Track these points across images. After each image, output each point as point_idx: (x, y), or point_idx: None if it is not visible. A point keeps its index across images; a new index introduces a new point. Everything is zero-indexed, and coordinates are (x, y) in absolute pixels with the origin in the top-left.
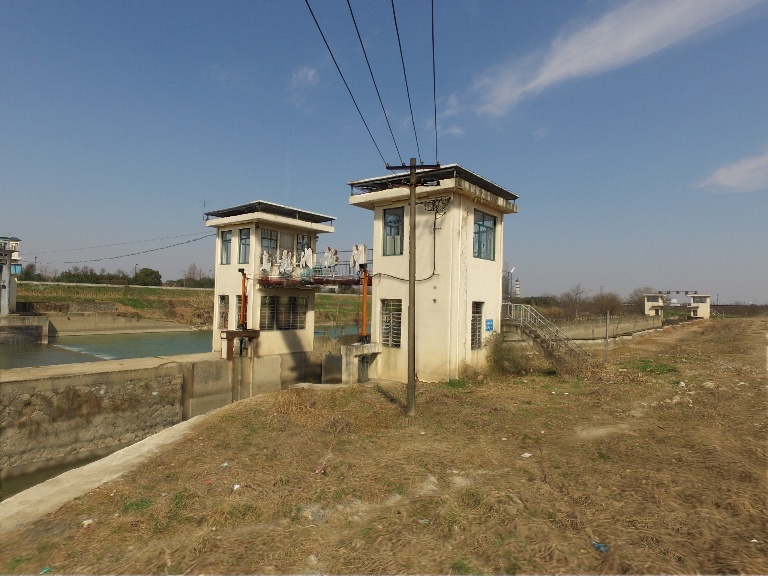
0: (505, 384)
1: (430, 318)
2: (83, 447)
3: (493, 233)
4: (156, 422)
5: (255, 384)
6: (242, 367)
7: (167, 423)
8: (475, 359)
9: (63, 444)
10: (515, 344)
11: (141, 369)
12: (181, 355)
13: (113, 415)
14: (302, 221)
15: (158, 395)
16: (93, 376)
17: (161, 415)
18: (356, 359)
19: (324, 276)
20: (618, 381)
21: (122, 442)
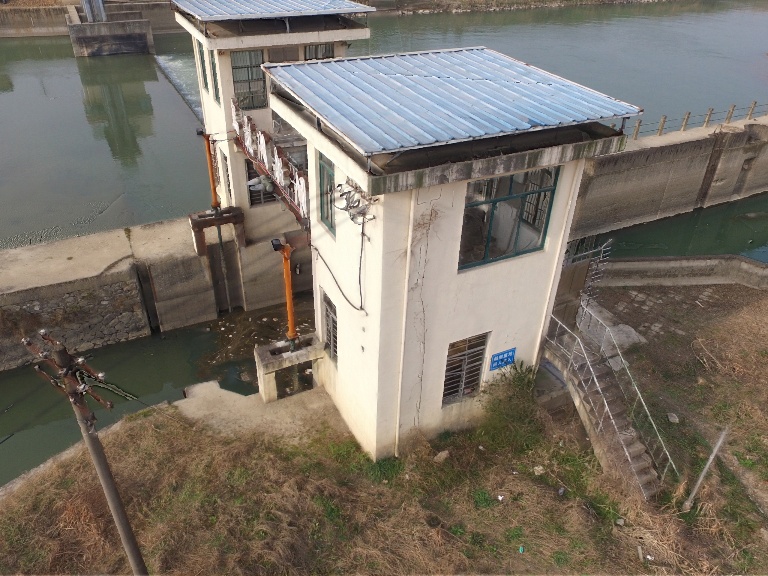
0: (460, 495)
1: (360, 366)
2: (36, 358)
3: (550, 195)
4: (116, 329)
5: (247, 277)
6: (229, 255)
7: (130, 329)
8: (454, 415)
9: (12, 358)
10: (533, 408)
11: (79, 279)
12: (160, 227)
13: (59, 328)
14: (298, 34)
15: (110, 304)
16: (20, 294)
17: (120, 322)
18: (270, 375)
19: (282, 188)
20: (657, 569)
21: (80, 351)
